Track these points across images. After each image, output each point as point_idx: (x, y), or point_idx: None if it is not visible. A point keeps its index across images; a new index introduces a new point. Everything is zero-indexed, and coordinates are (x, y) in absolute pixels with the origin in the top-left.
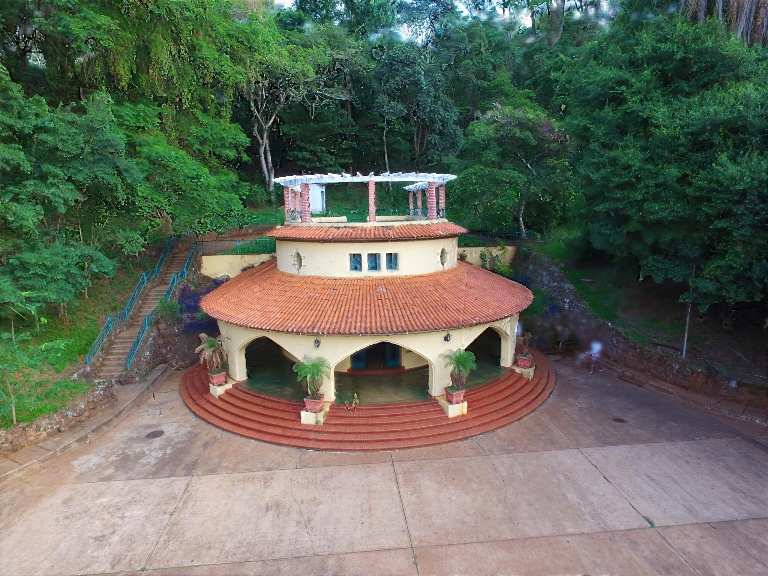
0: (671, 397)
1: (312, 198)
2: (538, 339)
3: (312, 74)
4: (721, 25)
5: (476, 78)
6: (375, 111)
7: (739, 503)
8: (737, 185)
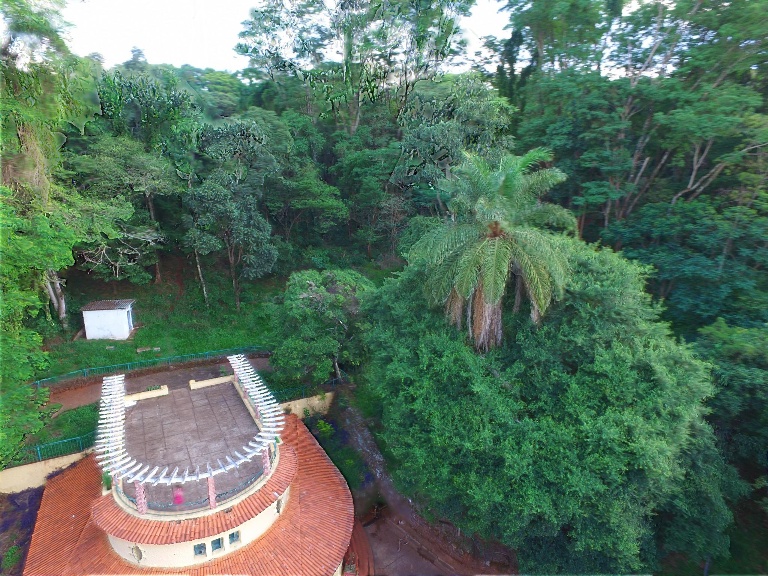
0: (452, 574)
1: (116, 324)
2: (358, 509)
3: (113, 236)
4: (470, 361)
5: (285, 179)
6: (186, 244)
7: None
8: (481, 505)
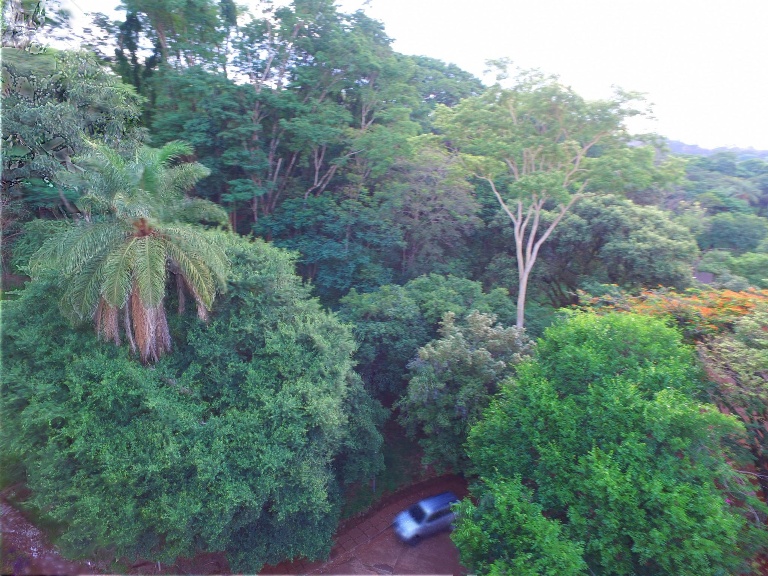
0: None
1: None
2: None
3: None
4: (138, 376)
5: None
6: None
7: None
8: (179, 524)
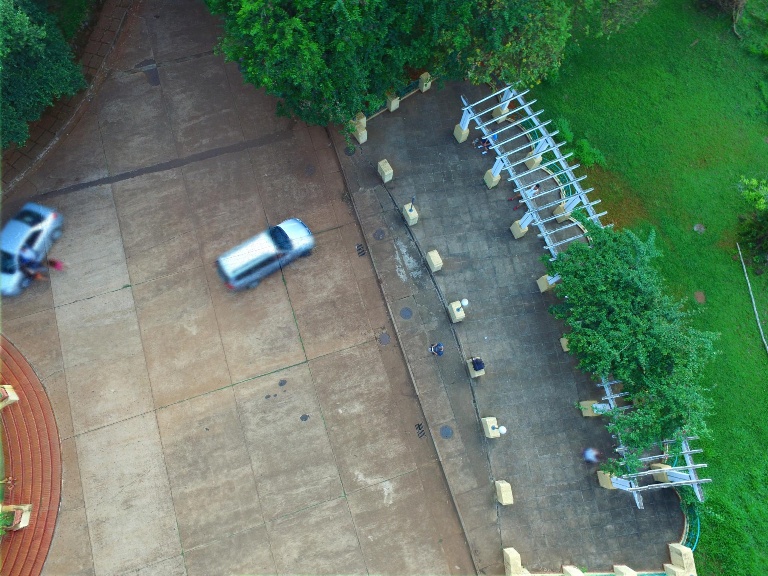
0: None
1: None
2: None
3: None
4: None
5: None
6: None
7: (109, 236)
8: None
